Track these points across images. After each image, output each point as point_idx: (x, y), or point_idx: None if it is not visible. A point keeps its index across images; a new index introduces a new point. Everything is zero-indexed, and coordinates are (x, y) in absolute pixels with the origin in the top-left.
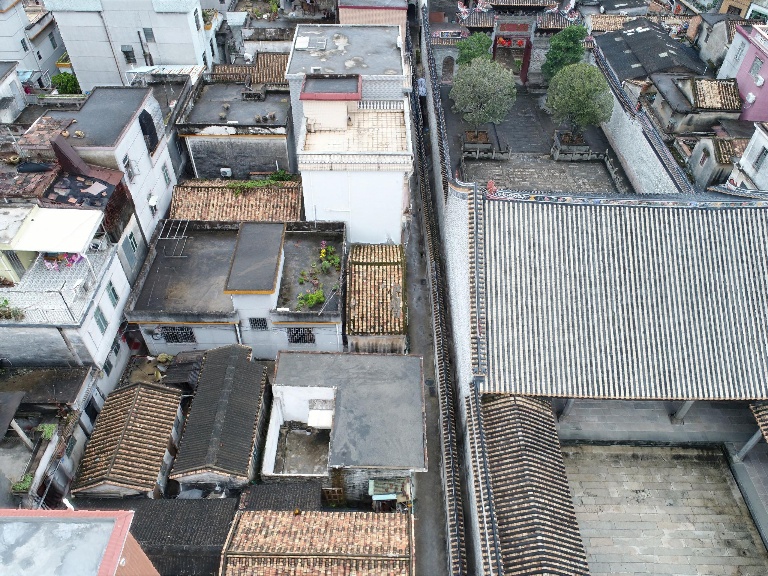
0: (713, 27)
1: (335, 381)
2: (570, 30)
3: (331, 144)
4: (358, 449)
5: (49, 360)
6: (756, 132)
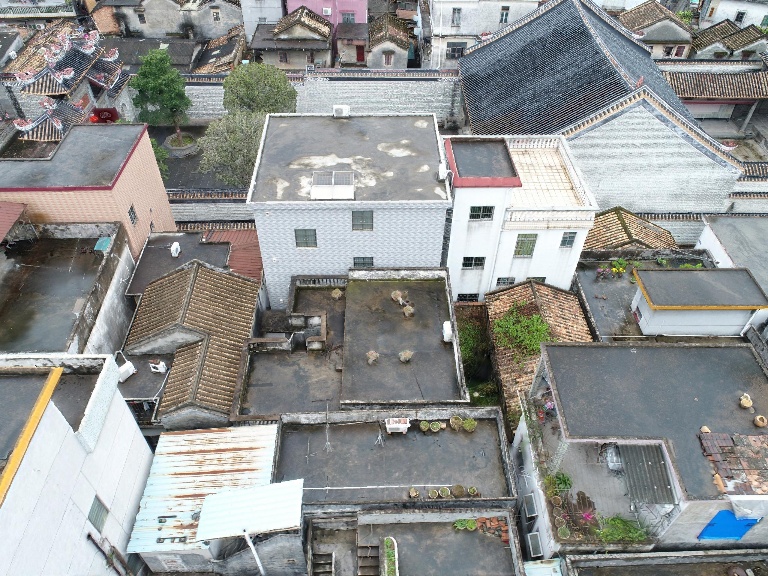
0: (143, 5)
1: (764, 264)
2: (161, 59)
3: (535, 201)
4: None
5: None
6: (438, 5)
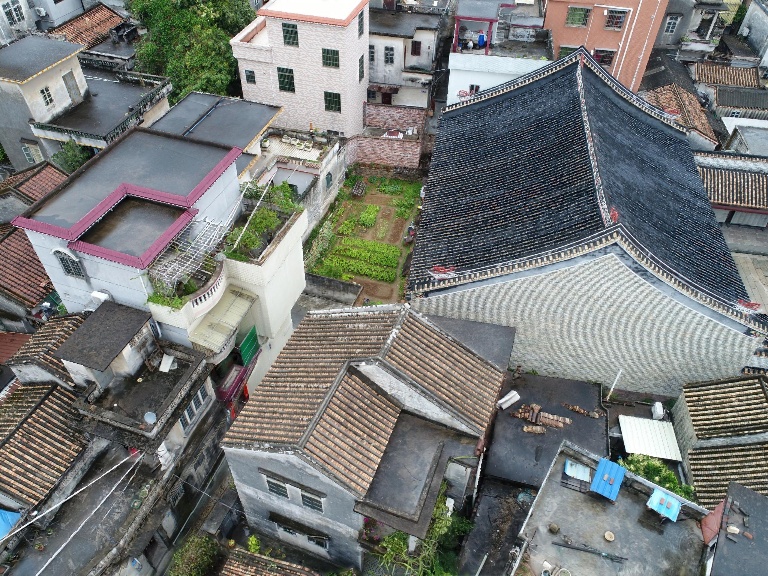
0: None
1: None
2: None
3: None
4: (753, 136)
5: (756, 46)
6: None
